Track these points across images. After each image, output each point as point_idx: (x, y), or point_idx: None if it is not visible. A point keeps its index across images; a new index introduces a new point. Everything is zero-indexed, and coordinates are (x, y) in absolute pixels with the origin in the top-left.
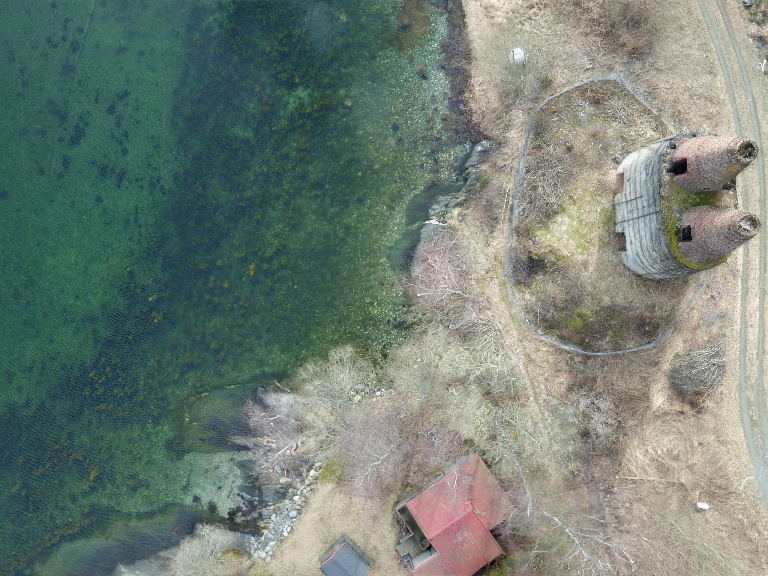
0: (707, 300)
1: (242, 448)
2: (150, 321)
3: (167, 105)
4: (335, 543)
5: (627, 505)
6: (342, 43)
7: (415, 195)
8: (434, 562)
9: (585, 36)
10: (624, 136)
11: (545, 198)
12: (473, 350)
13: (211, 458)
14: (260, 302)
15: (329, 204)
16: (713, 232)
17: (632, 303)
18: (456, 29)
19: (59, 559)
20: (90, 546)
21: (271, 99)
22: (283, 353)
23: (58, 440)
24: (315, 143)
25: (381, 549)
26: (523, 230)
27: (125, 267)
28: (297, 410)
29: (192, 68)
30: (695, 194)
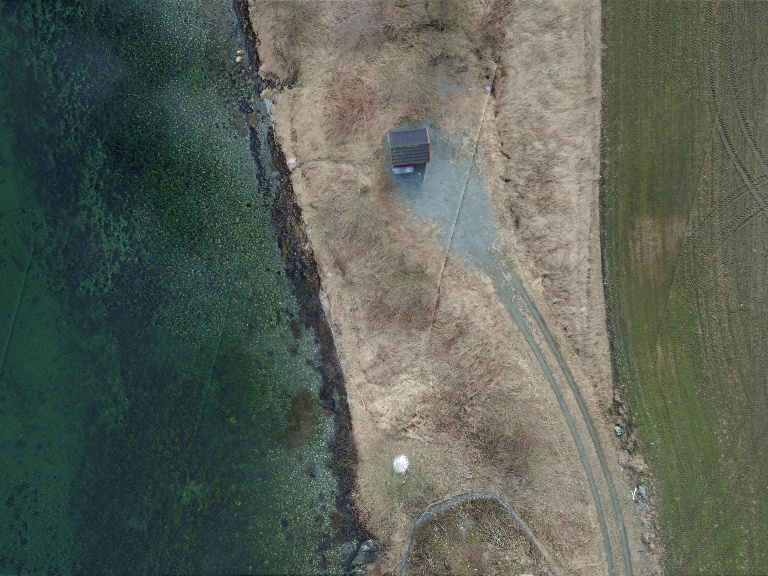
0: None
1: None
2: None
3: (65, 496)
4: None
5: None
6: (233, 440)
7: None
8: None
9: (466, 447)
10: (498, 563)
11: None
12: None
13: None
14: None
15: None
16: None
17: None
18: (343, 430)
19: None
20: None
21: (165, 493)
22: None
23: None
24: (207, 537)
25: None
26: None
27: None
28: None
29: (89, 461)
30: None
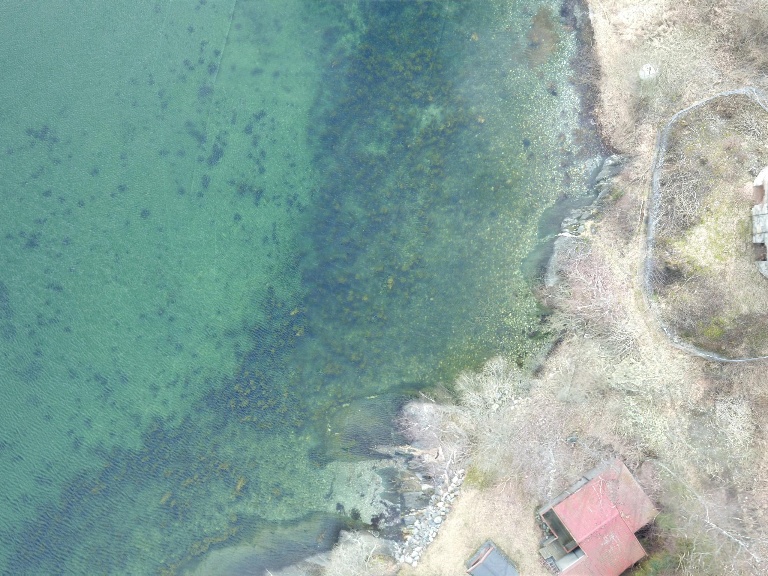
0: None
1: (384, 457)
2: (292, 335)
3: (302, 124)
4: (480, 547)
5: (765, 506)
6: (473, 61)
7: (547, 208)
8: (582, 564)
9: (714, 51)
10: (759, 149)
11: (683, 210)
12: (612, 359)
13: (353, 467)
14: (397, 315)
15: (463, 218)
16: None
17: None
18: (585, 46)
19: (208, 567)
20: (238, 554)
21: (404, 117)
22: (421, 364)
23: (204, 452)
24: (448, 159)
25: (524, 552)
26: (659, 241)
27: (264, 283)
28: (438, 419)
29: (326, 88)
30: None
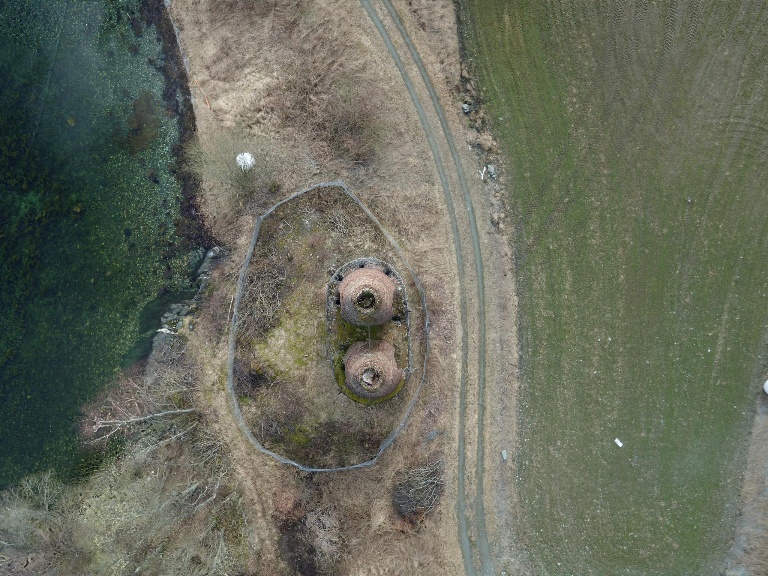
0: (425, 416)
1: None
2: None
3: None
4: None
5: None
6: (73, 147)
7: (148, 302)
8: None
9: (312, 140)
10: (340, 248)
11: (262, 312)
12: (196, 466)
13: None
14: None
15: (62, 312)
16: (351, 379)
17: (351, 419)
18: (187, 132)
19: None
20: None
21: (2, 204)
22: (16, 465)
23: None
24: (47, 249)
25: None
26: (245, 343)
27: None
28: (25, 526)
29: None
30: (361, 328)
